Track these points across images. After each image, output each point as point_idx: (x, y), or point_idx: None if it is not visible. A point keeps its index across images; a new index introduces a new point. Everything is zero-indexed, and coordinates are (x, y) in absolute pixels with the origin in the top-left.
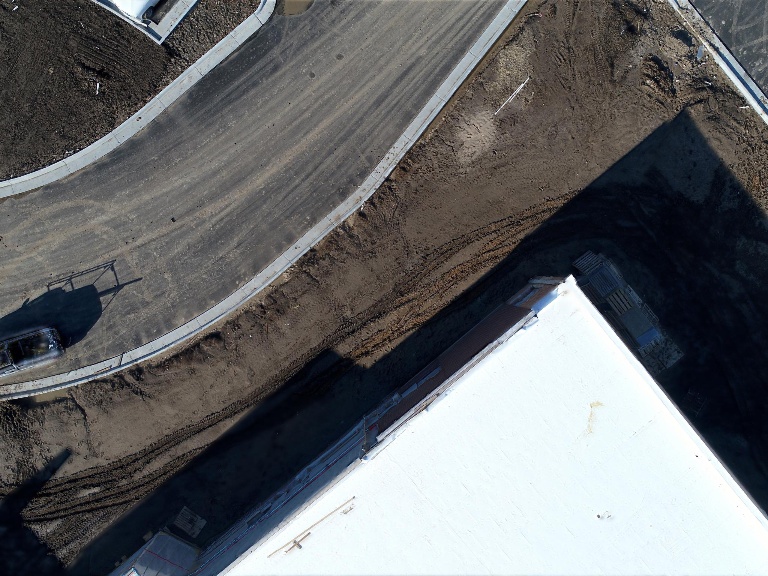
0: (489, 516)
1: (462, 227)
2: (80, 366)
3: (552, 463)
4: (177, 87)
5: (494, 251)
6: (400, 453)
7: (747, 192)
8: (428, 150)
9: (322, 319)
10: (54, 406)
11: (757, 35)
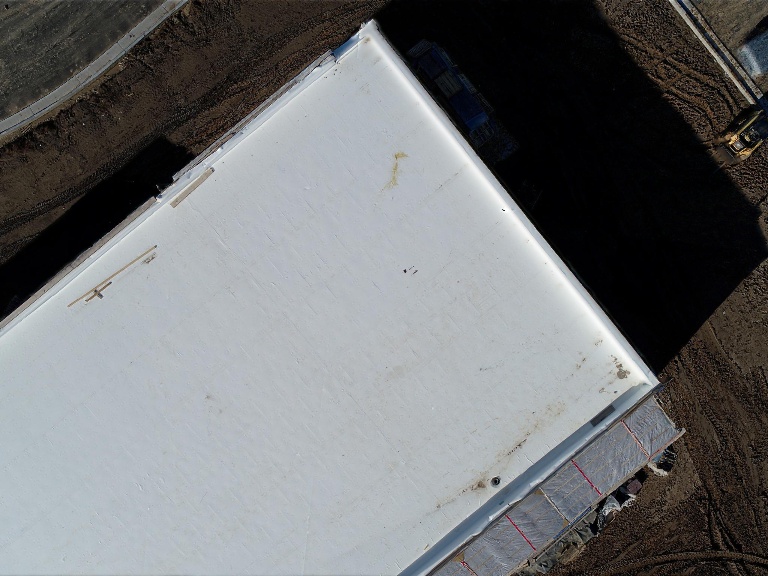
0: (294, 269)
1: (296, 15)
2: None
3: (357, 215)
4: None
5: (328, 39)
6: (202, 202)
7: None
8: None
9: (155, 107)
10: None
11: None
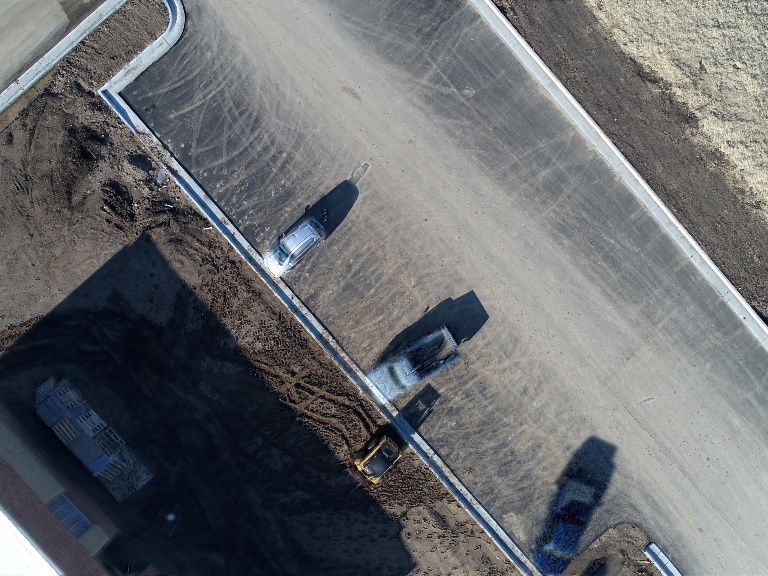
0: None
1: None
2: None
3: None
4: None
5: None
6: None
7: (212, 313)
8: None
9: None
10: None
11: (217, 157)
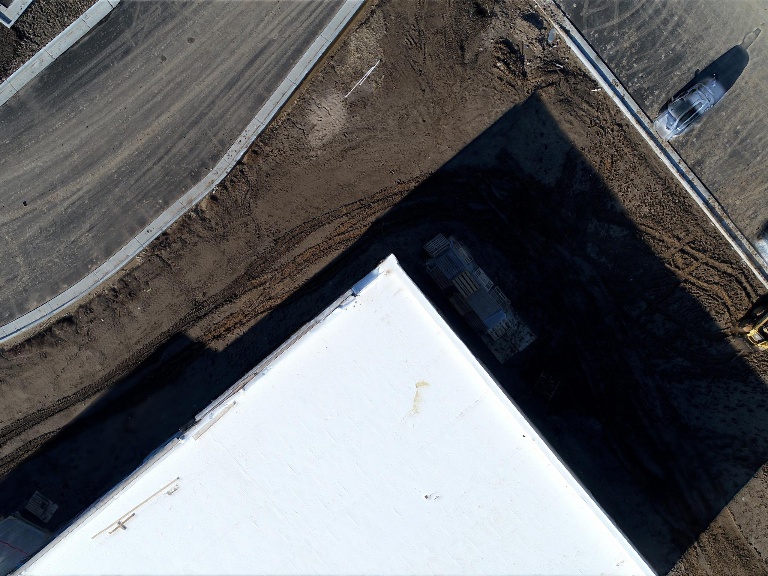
0: (316, 497)
1: (313, 210)
2: None
3: (378, 443)
4: (28, 71)
5: (345, 234)
6: (224, 433)
7: (599, 175)
8: (280, 133)
9: (173, 303)
10: None
11: (608, 18)
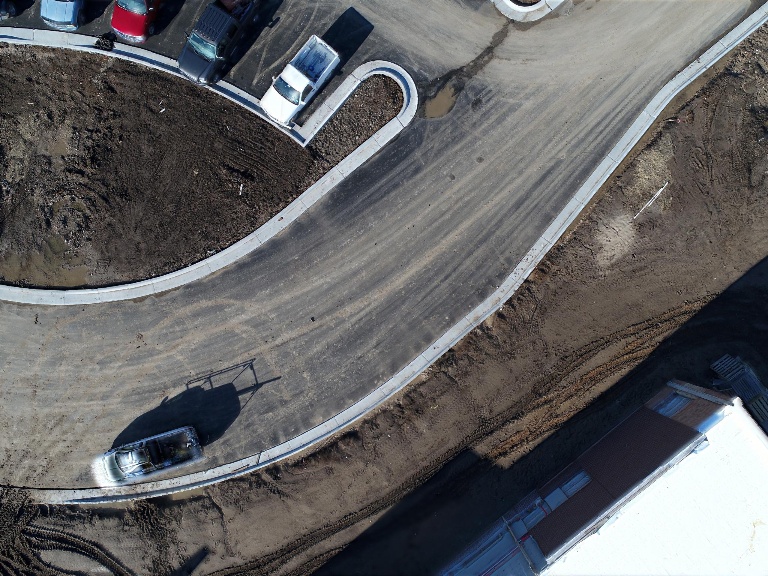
0: None
1: (601, 329)
2: (217, 464)
3: None
4: (319, 188)
5: (633, 354)
6: (564, 572)
7: None
8: (567, 252)
9: (461, 420)
10: (191, 505)
11: None
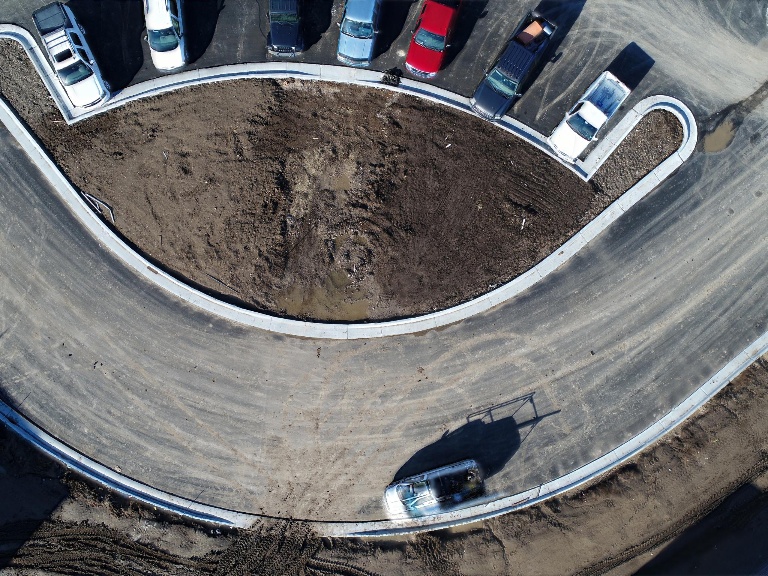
0: None
1: None
2: (498, 497)
3: None
4: (599, 222)
5: None
6: None
7: None
8: None
9: (741, 453)
10: (472, 538)
11: None
